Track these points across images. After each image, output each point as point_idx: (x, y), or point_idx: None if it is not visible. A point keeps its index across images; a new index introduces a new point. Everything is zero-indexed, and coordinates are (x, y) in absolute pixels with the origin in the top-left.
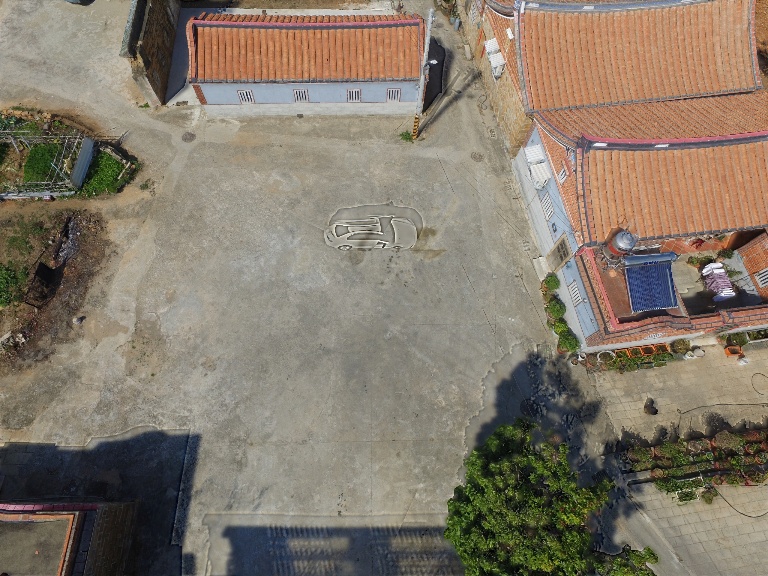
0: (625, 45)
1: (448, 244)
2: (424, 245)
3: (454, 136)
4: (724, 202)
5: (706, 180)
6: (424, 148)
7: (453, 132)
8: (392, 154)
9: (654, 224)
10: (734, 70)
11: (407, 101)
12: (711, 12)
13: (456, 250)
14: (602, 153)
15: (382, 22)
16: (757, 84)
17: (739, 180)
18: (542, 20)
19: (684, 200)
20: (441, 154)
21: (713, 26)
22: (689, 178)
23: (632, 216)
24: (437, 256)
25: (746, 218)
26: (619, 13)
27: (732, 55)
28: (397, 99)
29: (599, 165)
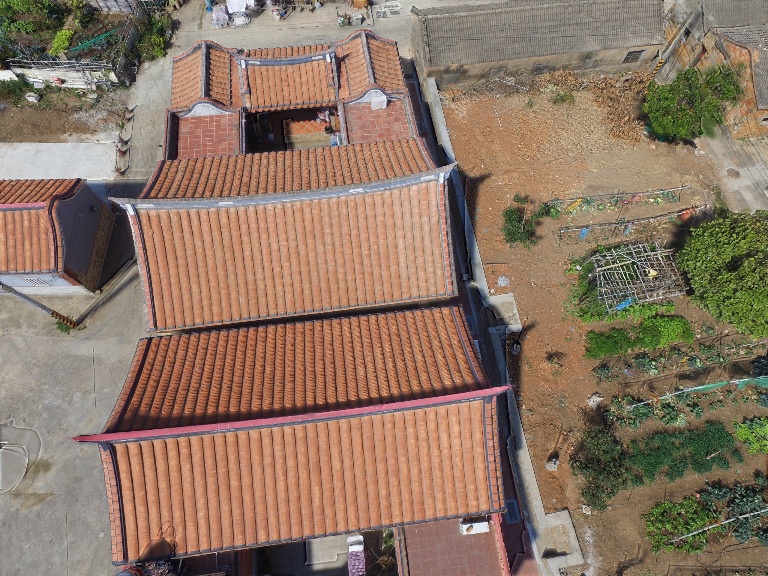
0: (281, 243)
1: (60, 484)
2: (29, 486)
3: (125, 322)
4: (313, 497)
5: (290, 468)
6: (80, 341)
7: (125, 317)
8: (37, 350)
9: (212, 531)
10: (420, 272)
11: (60, 285)
12: (390, 202)
13: (67, 493)
14: (136, 445)
15: (1, 205)
16: (448, 290)
17: (336, 467)
18: (165, 219)
19: (257, 497)
20: (99, 349)
21: (395, 218)
22: (267, 466)
23: (180, 523)
24: (39, 503)
25: (340, 519)
26: (271, 206)
27: (418, 253)
28: (46, 284)
29: (133, 460)
